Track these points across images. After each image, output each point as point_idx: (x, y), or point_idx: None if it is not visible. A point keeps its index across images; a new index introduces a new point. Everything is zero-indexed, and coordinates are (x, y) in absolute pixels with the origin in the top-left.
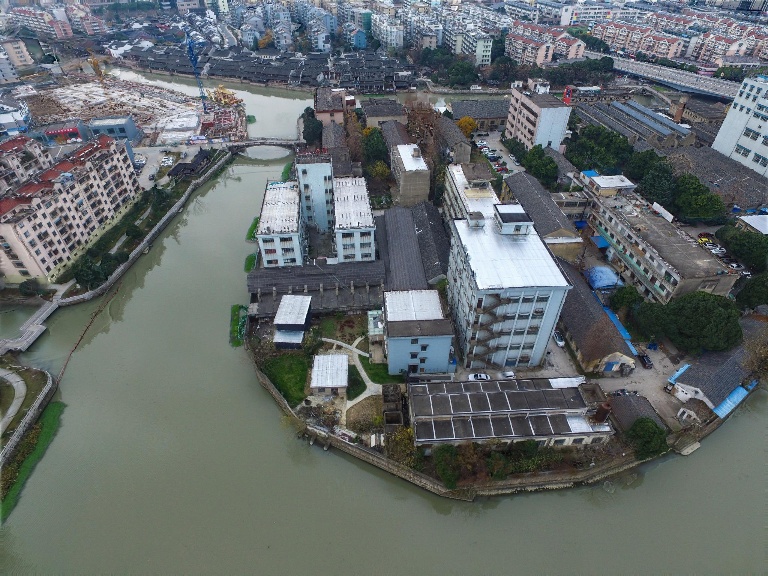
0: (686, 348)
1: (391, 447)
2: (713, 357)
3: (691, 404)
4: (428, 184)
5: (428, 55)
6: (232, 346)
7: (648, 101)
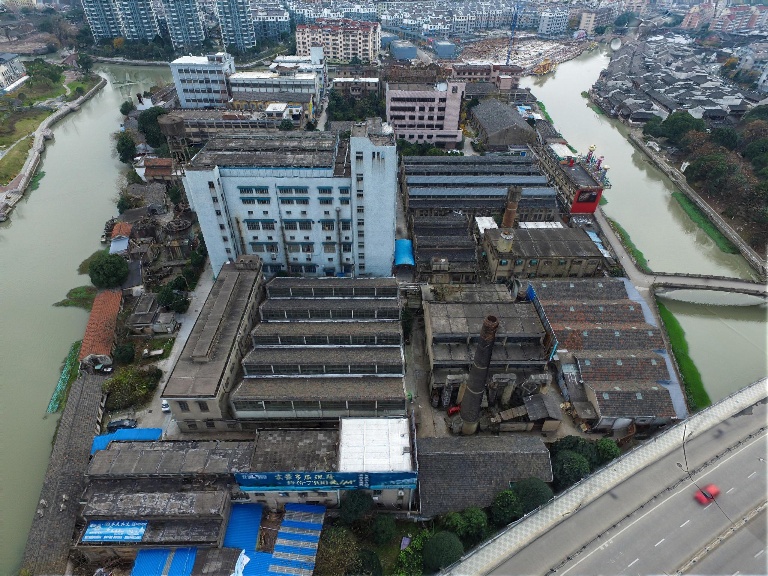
0: None
1: None
2: None
3: None
4: None
5: (755, 113)
6: None
7: (761, 310)
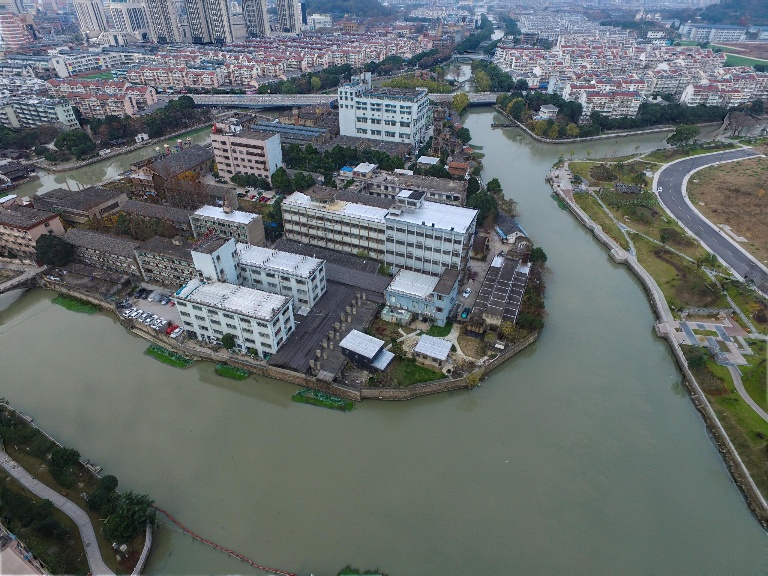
0: (488, 223)
1: (516, 334)
2: (499, 220)
3: (520, 240)
4: (263, 227)
5: None
6: (350, 410)
7: None
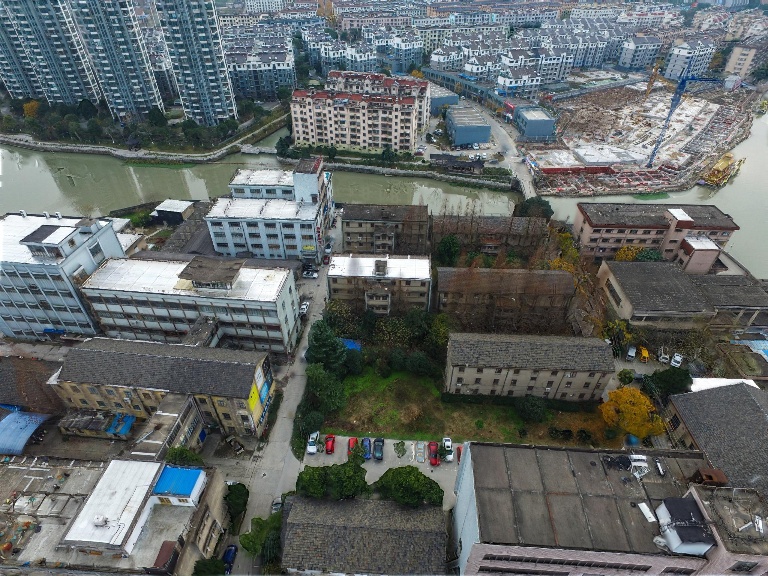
0: None
1: None
2: None
3: None
4: (328, 292)
5: None
6: None
7: None
